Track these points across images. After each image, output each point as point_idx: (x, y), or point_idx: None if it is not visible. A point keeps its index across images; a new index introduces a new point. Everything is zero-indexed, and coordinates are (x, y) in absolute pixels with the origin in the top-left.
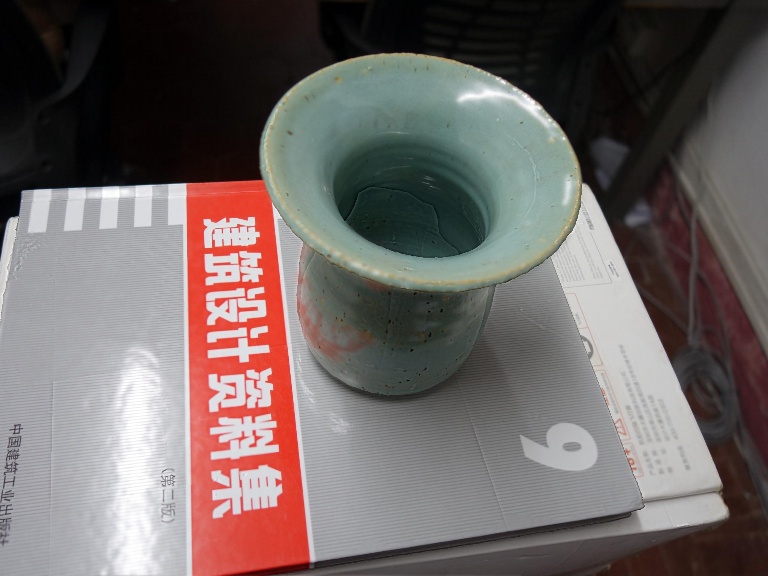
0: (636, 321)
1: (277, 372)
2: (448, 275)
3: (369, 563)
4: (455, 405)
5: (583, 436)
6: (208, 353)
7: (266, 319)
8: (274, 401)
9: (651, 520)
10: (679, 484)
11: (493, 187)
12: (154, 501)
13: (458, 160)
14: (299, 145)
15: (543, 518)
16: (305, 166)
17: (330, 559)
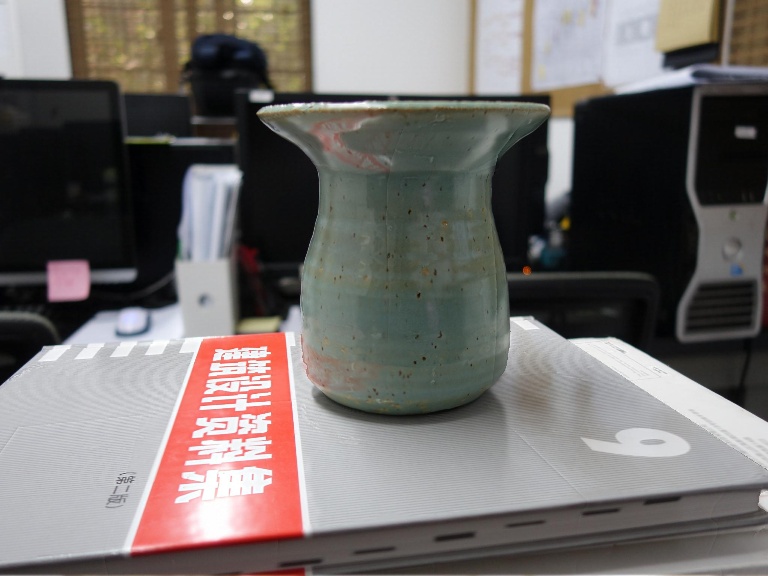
0: (701, 395)
1: (277, 414)
2: None
3: None
4: (492, 423)
5: (664, 435)
6: (200, 407)
7: (270, 389)
8: (271, 429)
9: None
10: None
11: None
12: (102, 493)
13: None
14: None
15: (634, 489)
16: None
17: (332, 531)
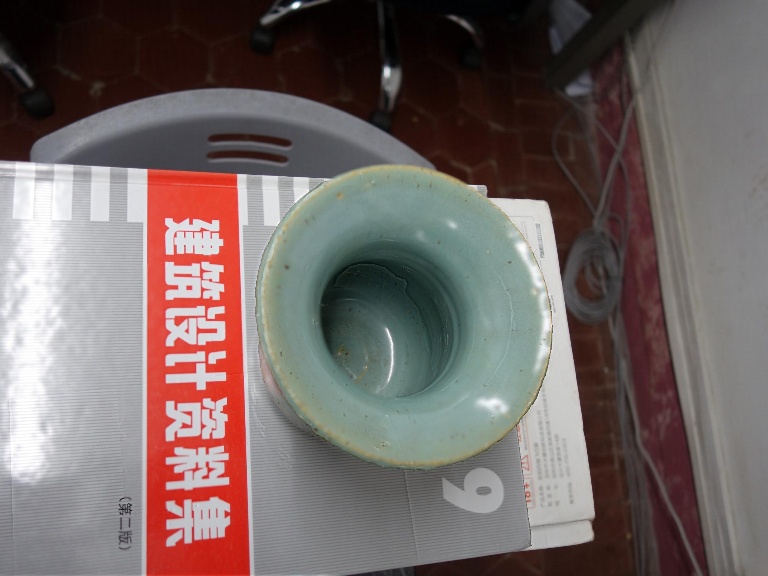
0: (561, 360)
1: (232, 402)
2: (420, 453)
3: None
4: None
5: (495, 481)
6: (166, 378)
7: (225, 343)
8: (228, 433)
9: (532, 541)
10: (561, 516)
11: (469, 313)
12: (112, 529)
13: (441, 271)
14: (294, 279)
15: (449, 555)
16: (298, 304)
17: None
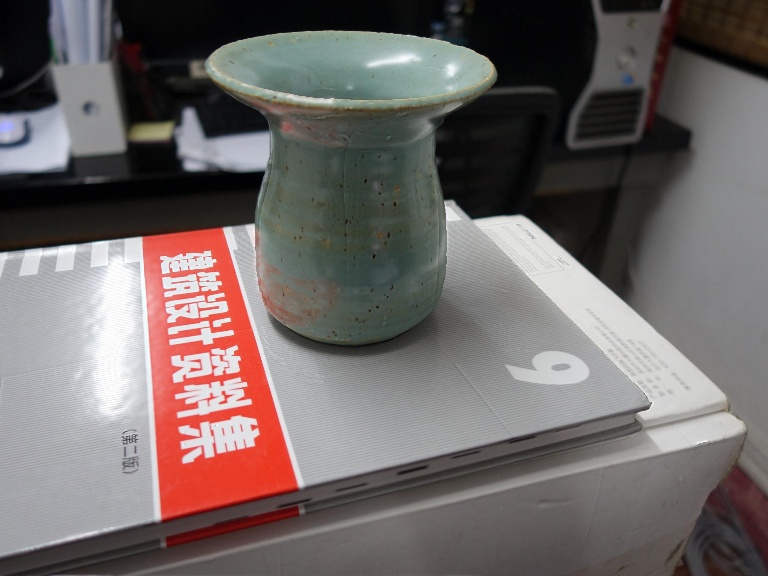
0: (596, 291)
1: (244, 347)
2: None
3: (369, 515)
4: (433, 351)
5: (570, 358)
6: (170, 341)
7: (228, 313)
8: (243, 368)
9: (667, 442)
10: (684, 402)
11: None
12: (114, 457)
13: None
14: (241, 71)
15: (548, 422)
16: (248, 81)
17: (321, 483)
